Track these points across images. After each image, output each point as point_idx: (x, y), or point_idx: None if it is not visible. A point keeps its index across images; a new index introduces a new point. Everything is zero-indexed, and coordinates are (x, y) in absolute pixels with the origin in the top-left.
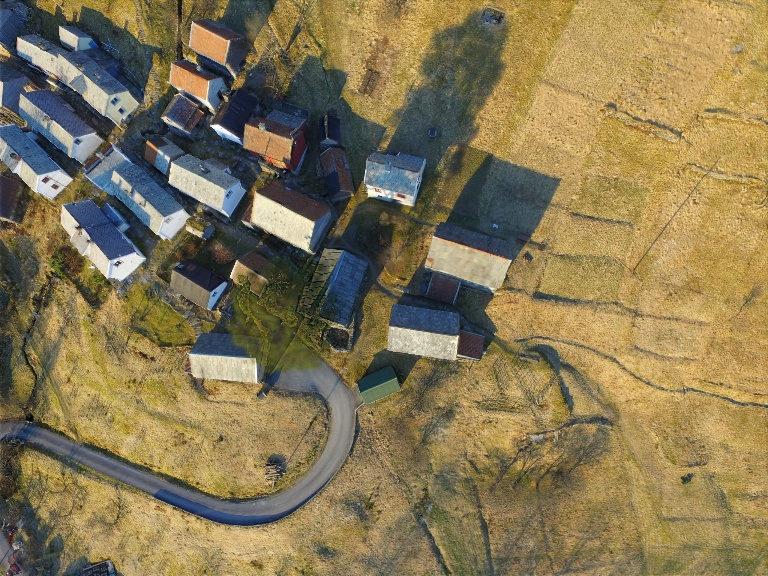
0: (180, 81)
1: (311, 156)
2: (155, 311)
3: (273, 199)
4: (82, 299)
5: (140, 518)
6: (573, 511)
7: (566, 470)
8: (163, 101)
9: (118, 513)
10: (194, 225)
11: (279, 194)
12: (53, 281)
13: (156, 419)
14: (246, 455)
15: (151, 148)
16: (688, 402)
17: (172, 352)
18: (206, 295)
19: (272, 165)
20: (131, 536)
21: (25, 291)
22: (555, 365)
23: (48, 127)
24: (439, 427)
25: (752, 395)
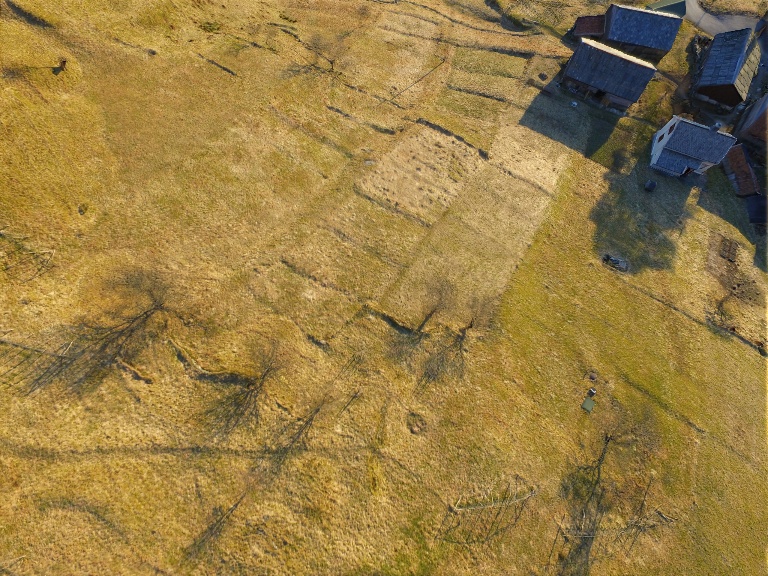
0: None
1: None
2: None
3: None
4: None
5: None
6: None
7: None
8: None
9: None
10: None
11: None
12: None
13: None
14: None
15: None
16: None
17: None
18: None
19: None
20: None
21: None
22: (506, 20)
23: None
24: None
25: None
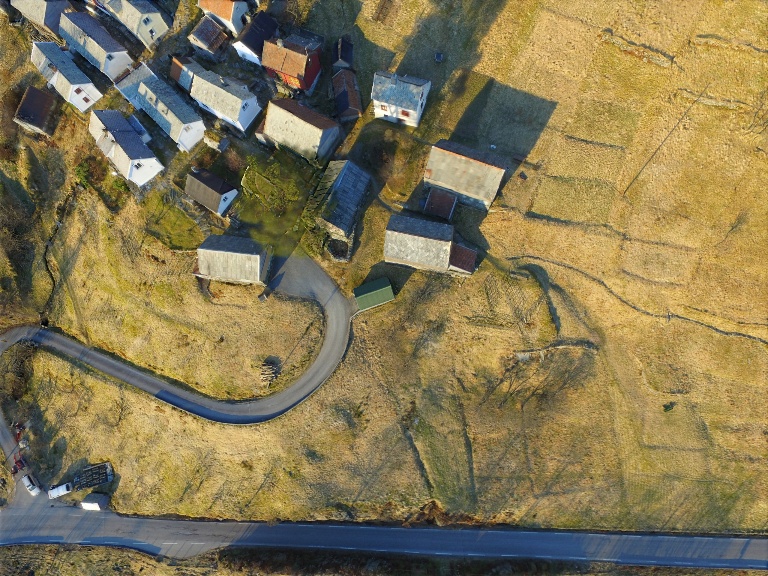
0: (208, 3)
1: (324, 79)
2: (169, 216)
3: (285, 109)
4: (102, 206)
5: (140, 419)
6: (556, 434)
7: (551, 393)
8: (191, 26)
9: (120, 415)
10: (211, 135)
11: (291, 106)
12: (77, 190)
13: (162, 320)
14: (244, 356)
15: (176, 65)
16: (673, 329)
17: (182, 256)
18: (217, 198)
19: (287, 85)
20: (131, 438)
21: (51, 201)
22: (544, 285)
23: (84, 44)
24: (429, 341)
25: (736, 324)
